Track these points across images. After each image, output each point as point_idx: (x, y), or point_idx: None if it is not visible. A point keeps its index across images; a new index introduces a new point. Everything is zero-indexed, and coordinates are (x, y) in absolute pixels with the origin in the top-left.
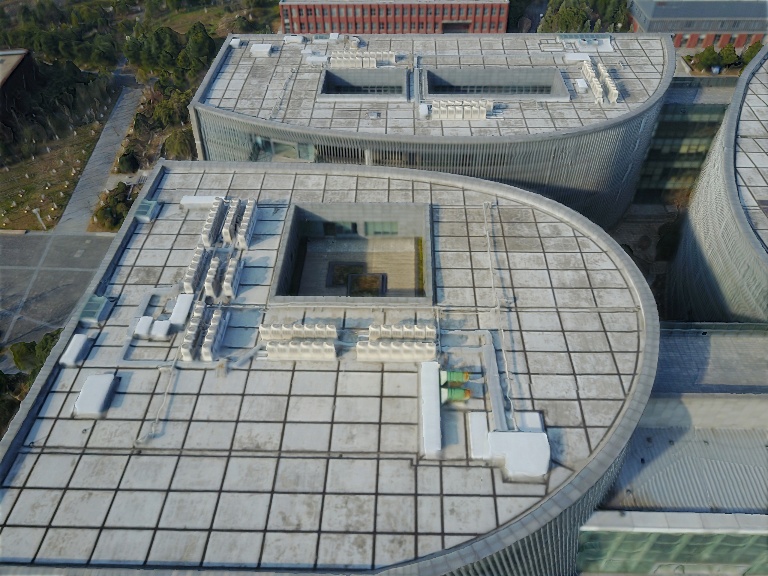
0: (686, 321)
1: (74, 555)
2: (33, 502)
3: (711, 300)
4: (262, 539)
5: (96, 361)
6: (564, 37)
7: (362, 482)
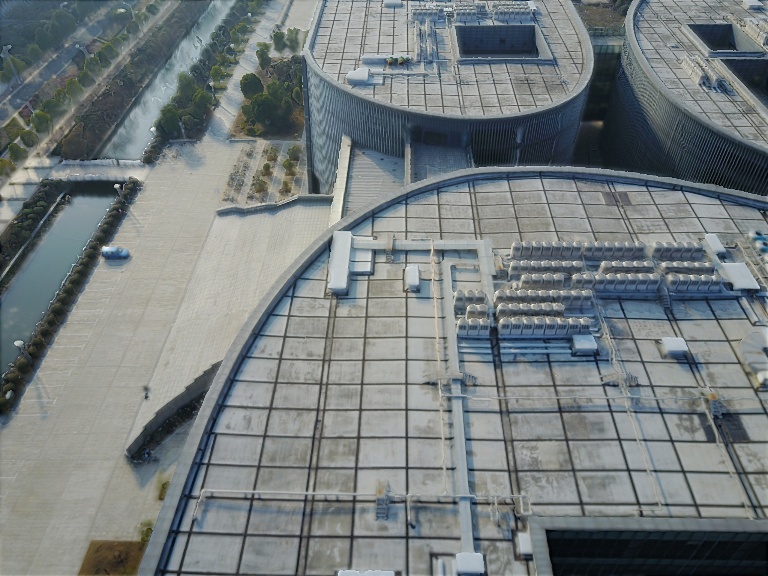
0: None
1: (326, 11)
2: (347, 3)
3: None
4: (327, 35)
5: (411, 2)
6: None
7: (349, 50)
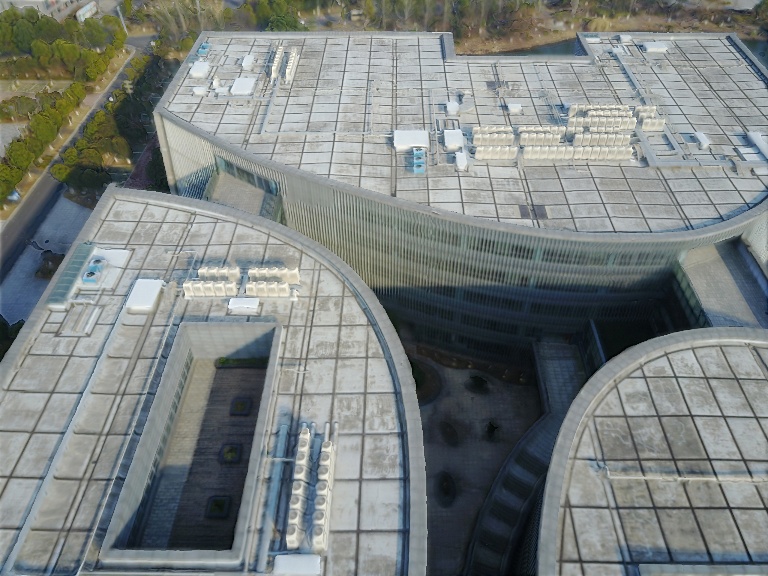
0: (537, 341)
1: None
2: None
3: (575, 305)
4: None
5: None
6: (61, 297)
7: None
